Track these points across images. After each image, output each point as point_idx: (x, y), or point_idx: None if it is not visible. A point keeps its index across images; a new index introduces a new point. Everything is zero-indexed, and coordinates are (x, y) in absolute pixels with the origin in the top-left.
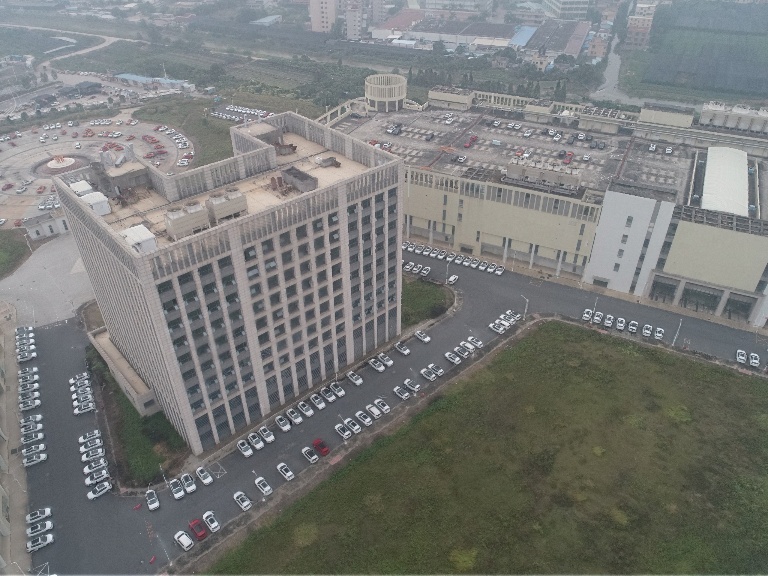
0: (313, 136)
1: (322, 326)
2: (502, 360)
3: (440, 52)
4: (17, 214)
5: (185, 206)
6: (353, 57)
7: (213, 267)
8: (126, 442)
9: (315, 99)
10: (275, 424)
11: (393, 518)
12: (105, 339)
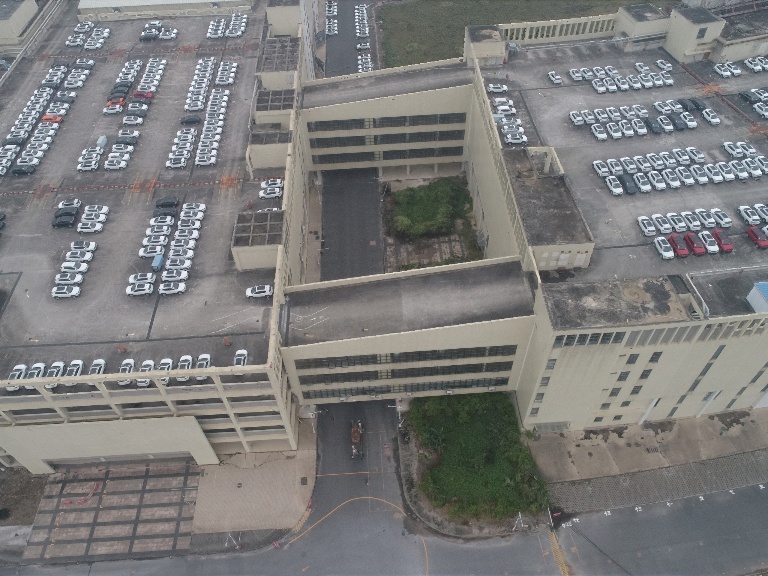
0: None
1: None
2: None
3: None
4: None
5: None
6: None
7: None
8: None
9: None
10: None
11: (491, 7)
12: None
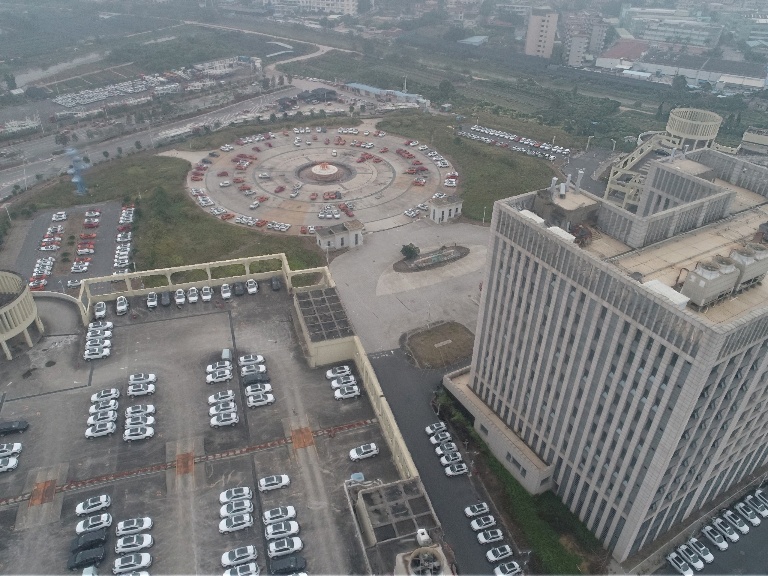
0: (744, 181)
1: None
2: None
3: (683, 87)
4: (298, 220)
5: (719, 264)
6: (580, 85)
7: (756, 348)
8: (523, 525)
9: (565, 127)
10: (702, 536)
11: None
12: (463, 386)
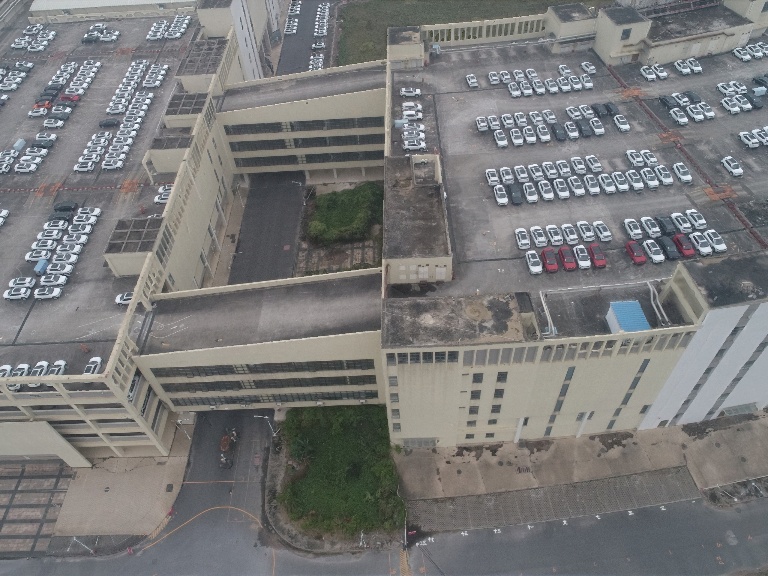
0: None
1: None
2: None
3: None
4: None
5: None
6: None
7: None
8: None
9: None
10: None
11: (455, 5)
12: None
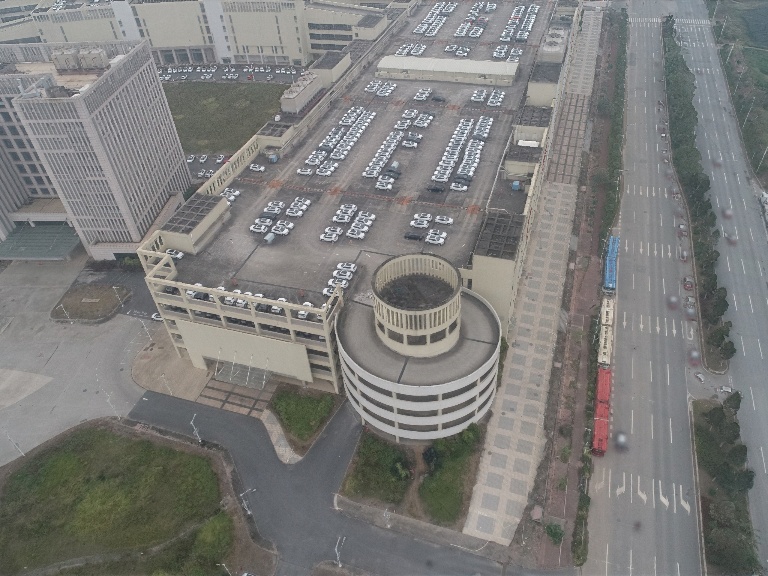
0: None
1: None
2: None
3: None
4: None
5: None
6: None
7: None
8: None
9: None
10: None
11: None
12: None
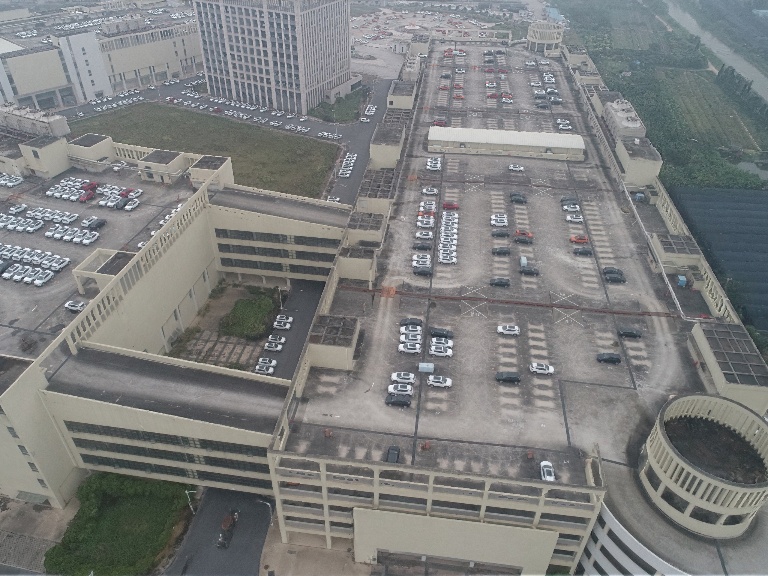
0: None
1: (261, 73)
2: (293, 137)
3: None
4: (355, 35)
5: None
6: (748, 54)
7: (213, 6)
8: None
9: None
10: None
11: None
12: None
